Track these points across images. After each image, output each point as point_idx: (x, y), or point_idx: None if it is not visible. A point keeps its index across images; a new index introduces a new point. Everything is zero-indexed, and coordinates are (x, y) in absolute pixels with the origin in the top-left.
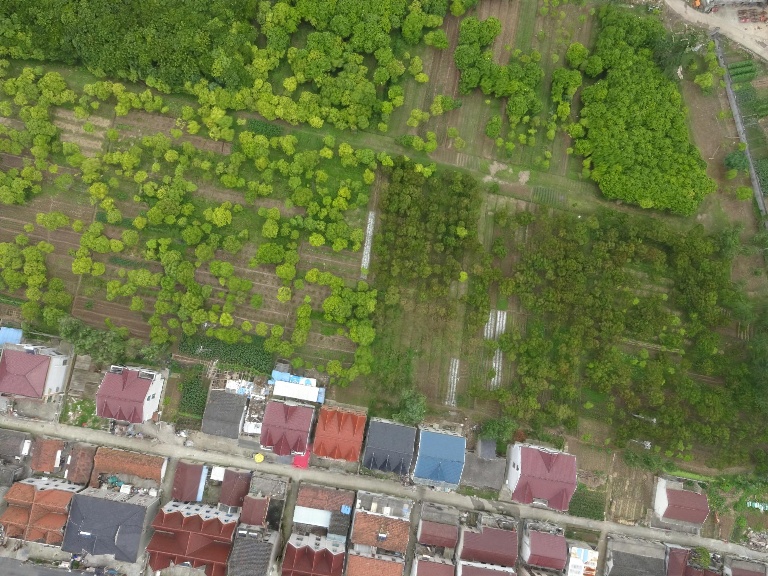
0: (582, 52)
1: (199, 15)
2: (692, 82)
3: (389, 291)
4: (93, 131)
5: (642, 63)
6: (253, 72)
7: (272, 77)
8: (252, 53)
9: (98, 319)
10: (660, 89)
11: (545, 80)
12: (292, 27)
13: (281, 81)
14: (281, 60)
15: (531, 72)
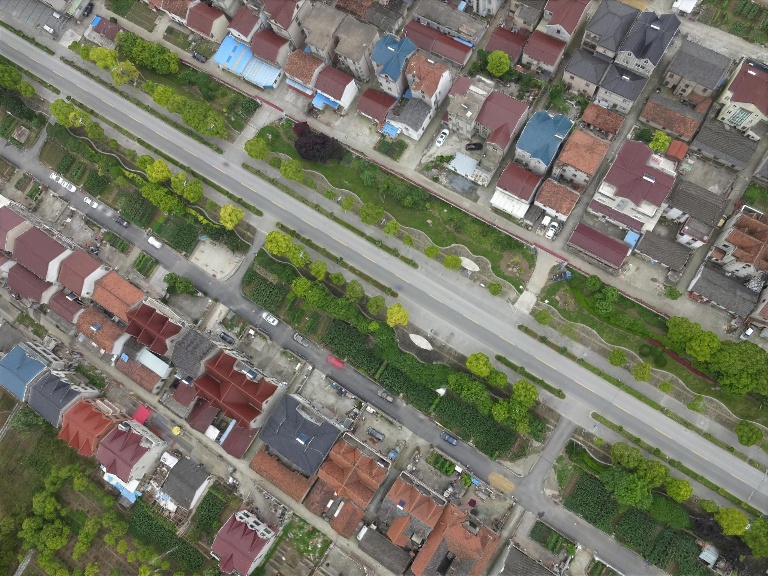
0: None
1: None
2: None
3: (8, 530)
4: None
5: None
6: None
7: None
8: None
9: None
10: None
11: None
12: None
13: None
14: None
15: None
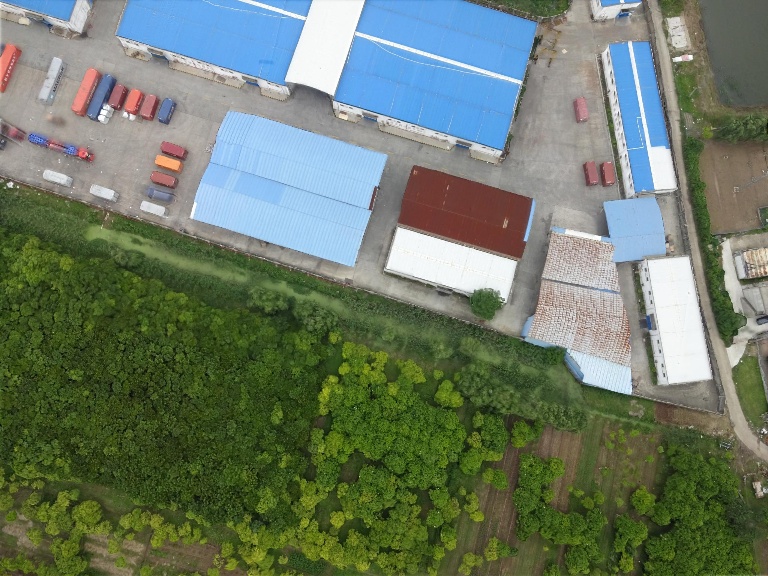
0: (649, 506)
1: (248, 451)
2: (763, 531)
3: None
4: (125, 558)
5: (713, 523)
6: (300, 512)
7: (319, 505)
8: (300, 492)
9: None
10: (732, 555)
11: (607, 518)
12: (344, 460)
13: (328, 508)
14: (330, 491)
15: (594, 526)
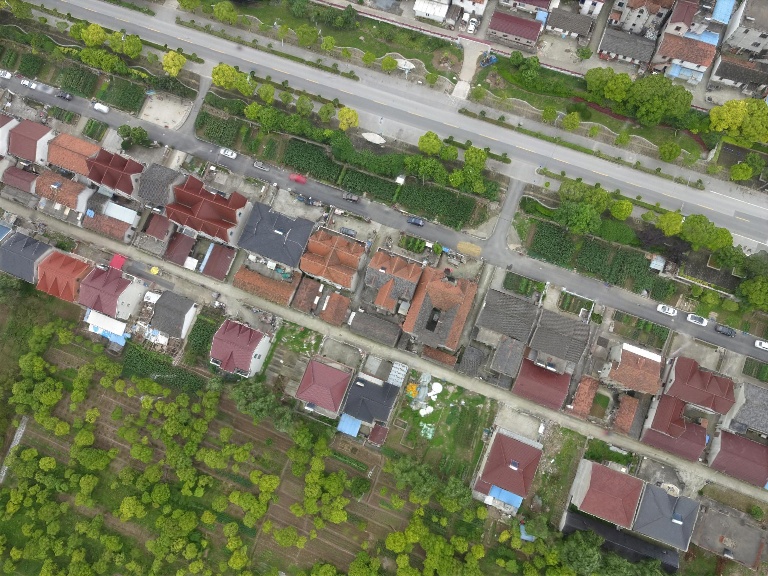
0: None
1: None
2: None
3: None
4: None
5: None
6: None
7: None
8: None
9: None
10: None
11: None
12: None
13: None
14: None
15: None
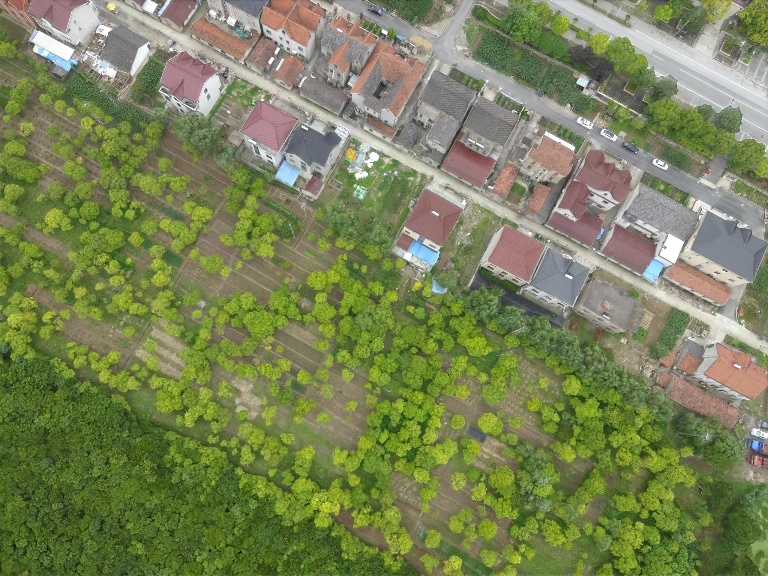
0: None
1: None
2: None
3: None
4: None
5: None
6: None
7: None
8: None
9: (213, 171)
10: None
11: None
12: None
13: None
14: None
15: None
